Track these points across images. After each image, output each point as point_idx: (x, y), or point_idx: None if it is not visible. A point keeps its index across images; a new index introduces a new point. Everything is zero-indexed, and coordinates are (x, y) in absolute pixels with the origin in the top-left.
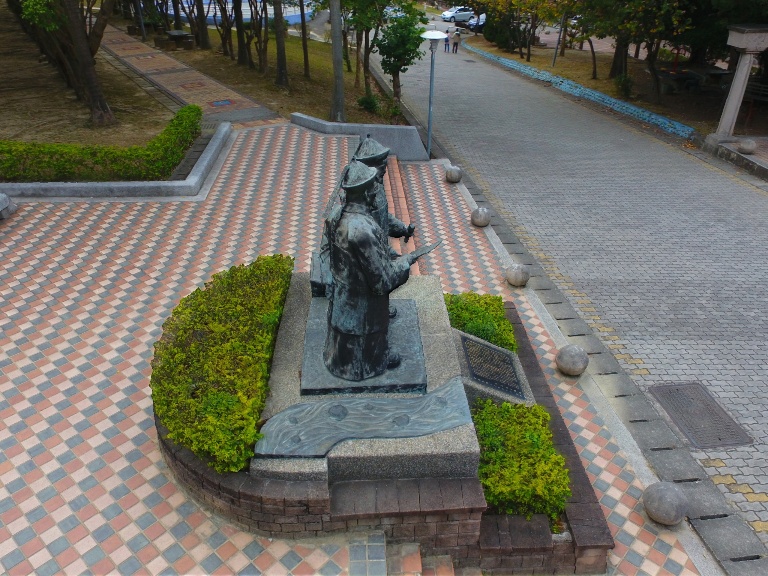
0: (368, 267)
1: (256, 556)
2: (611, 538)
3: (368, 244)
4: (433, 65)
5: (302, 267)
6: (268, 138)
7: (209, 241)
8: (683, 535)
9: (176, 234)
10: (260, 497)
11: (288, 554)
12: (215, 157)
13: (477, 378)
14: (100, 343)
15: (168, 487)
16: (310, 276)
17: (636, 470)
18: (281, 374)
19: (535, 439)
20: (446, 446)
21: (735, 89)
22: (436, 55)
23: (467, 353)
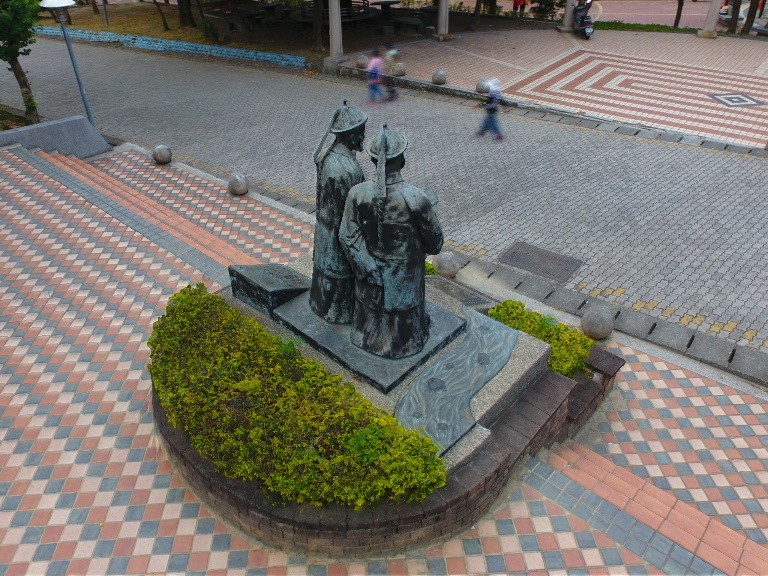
0: (431, 231)
1: (481, 548)
2: (620, 358)
3: (428, 207)
4: (68, 39)
5: (157, 301)
6: None
7: None
8: (616, 338)
9: None
10: (467, 493)
11: (498, 525)
12: None
13: None
14: (21, 516)
15: (334, 571)
16: (264, 288)
17: (554, 316)
18: None
19: (536, 323)
20: (531, 356)
21: (334, 14)
22: (68, 26)
23: None
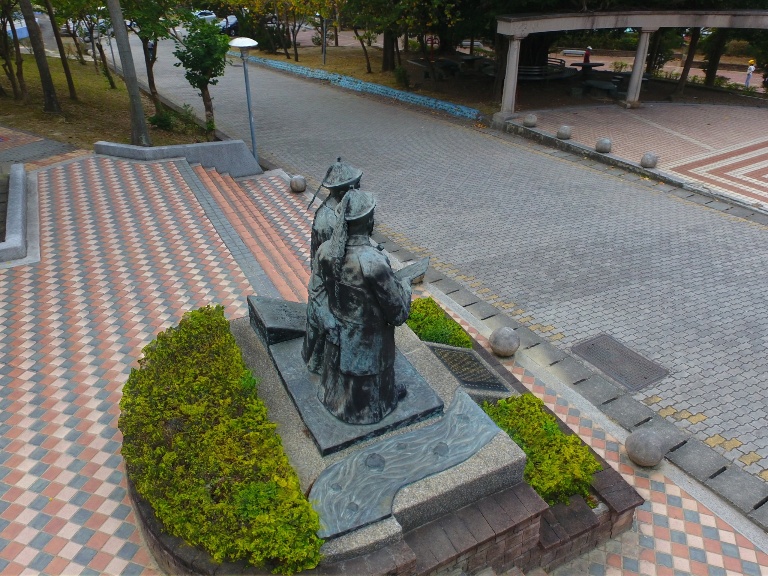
0: (388, 300)
1: None
2: (639, 495)
3: (386, 276)
4: (247, 74)
5: None
6: (78, 175)
7: (76, 309)
8: (666, 470)
9: (26, 309)
10: None
11: None
12: (24, 207)
13: (468, 384)
14: (2, 471)
15: None
16: (263, 323)
17: (603, 426)
18: (285, 440)
19: (544, 427)
20: (496, 461)
21: (510, 72)
22: (248, 63)
23: (444, 362)
